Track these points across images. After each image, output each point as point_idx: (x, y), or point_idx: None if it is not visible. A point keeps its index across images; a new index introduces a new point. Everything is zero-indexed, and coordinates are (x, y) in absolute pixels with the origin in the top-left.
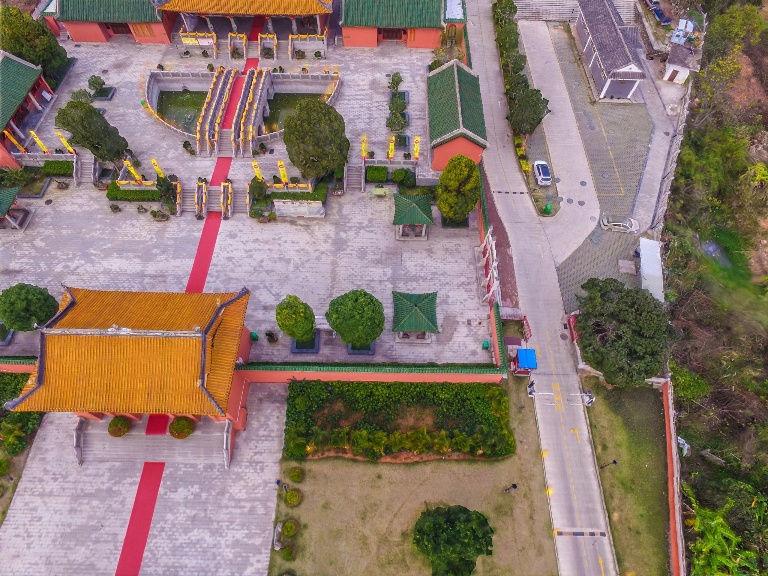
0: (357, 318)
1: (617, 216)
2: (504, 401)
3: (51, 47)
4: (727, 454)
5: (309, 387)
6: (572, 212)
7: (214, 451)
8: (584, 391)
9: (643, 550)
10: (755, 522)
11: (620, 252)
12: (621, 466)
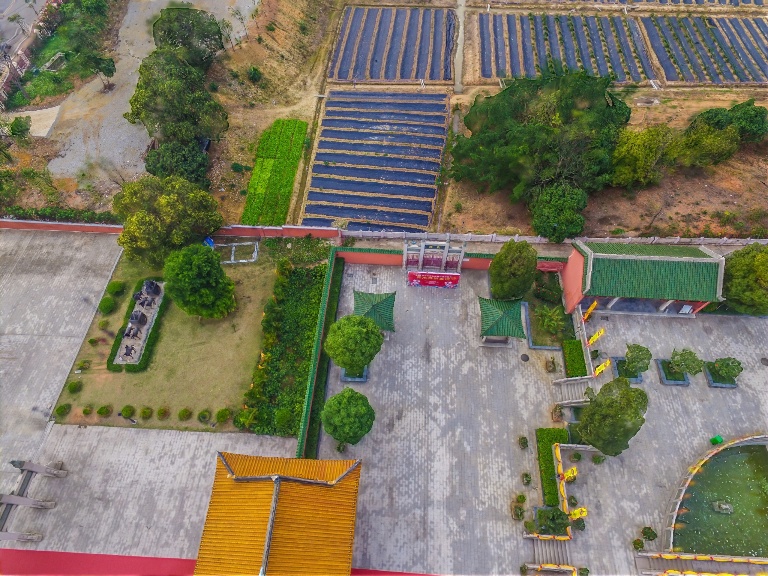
0: None
1: None
2: None
3: (763, 304)
4: None
5: None
6: None
7: None
8: None
9: None
10: None
11: None
12: None
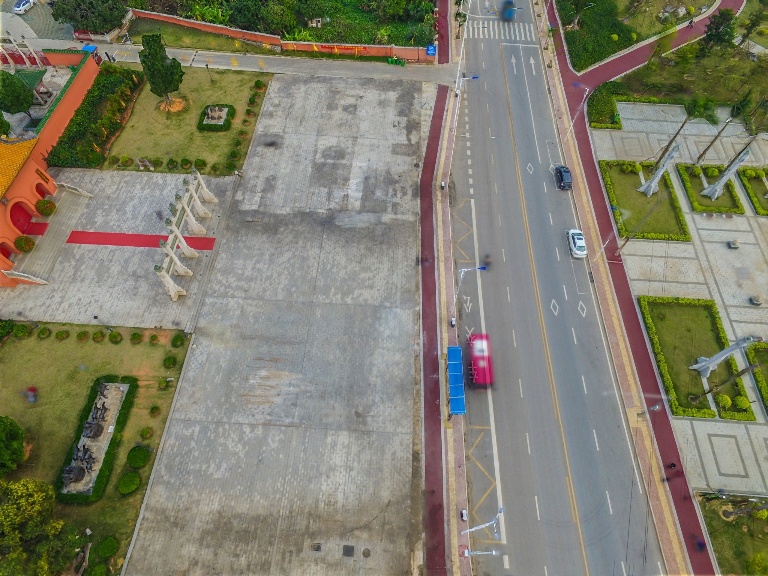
0: (6, 77)
1: (17, 2)
2: (111, 65)
3: None
4: (179, 8)
5: (55, 152)
6: (0, 24)
7: (76, 200)
8: (124, 43)
9: (207, 40)
10: (206, 4)
11: (45, 12)
12: (168, 39)
